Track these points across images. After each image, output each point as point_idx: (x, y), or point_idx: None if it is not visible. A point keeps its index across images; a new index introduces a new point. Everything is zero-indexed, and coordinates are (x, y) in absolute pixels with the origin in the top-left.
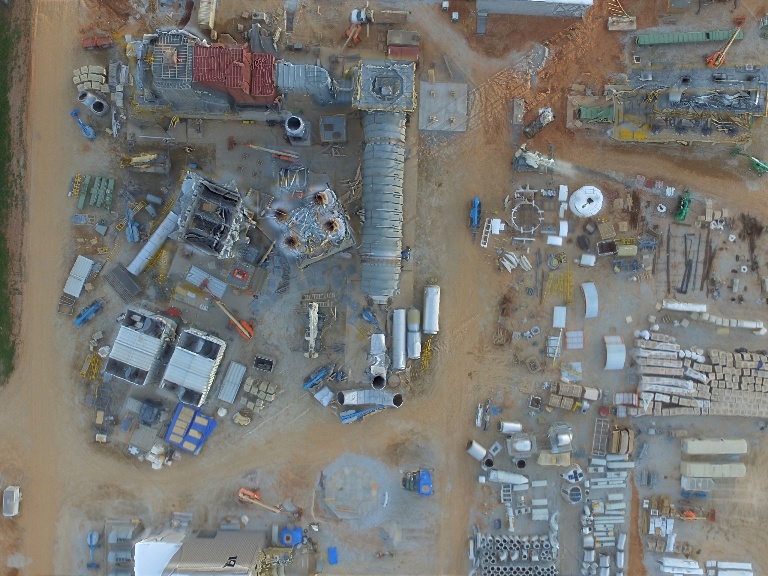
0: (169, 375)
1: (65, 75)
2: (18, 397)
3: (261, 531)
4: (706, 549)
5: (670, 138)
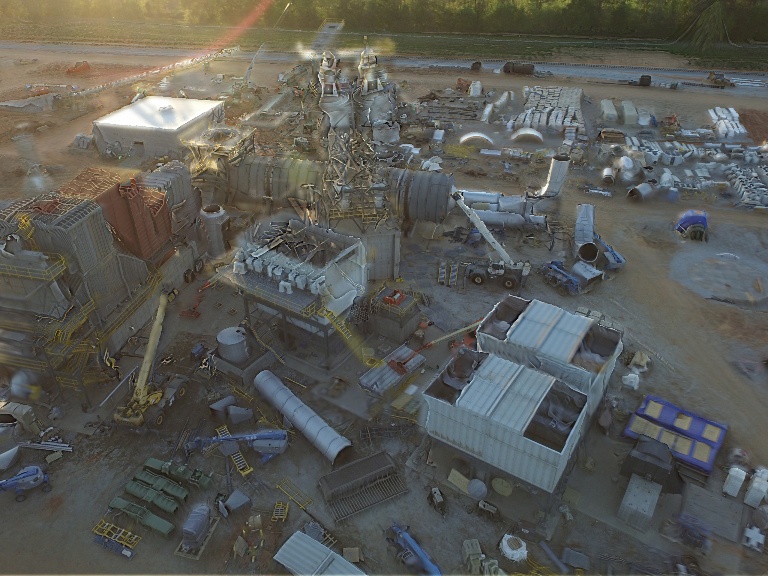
0: (563, 354)
1: None
2: None
3: None
4: (704, 123)
5: None
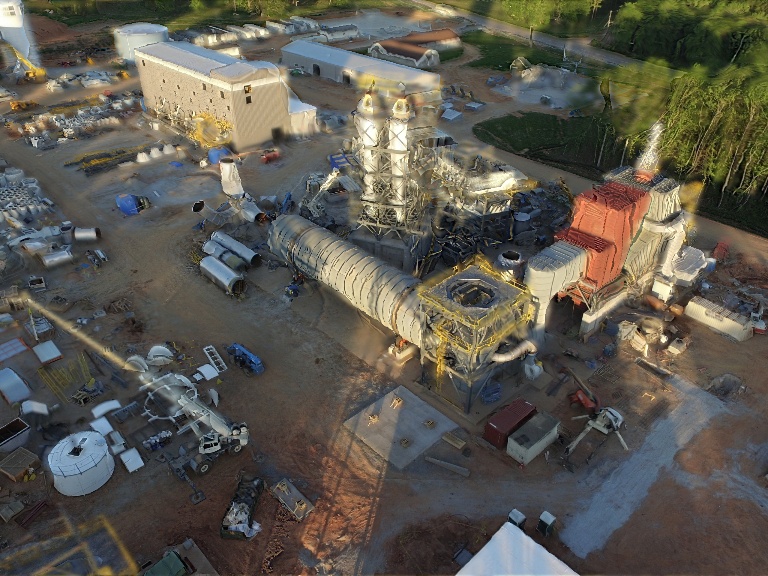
0: None
1: (698, 231)
2: (462, 136)
3: (244, 151)
4: None
5: None
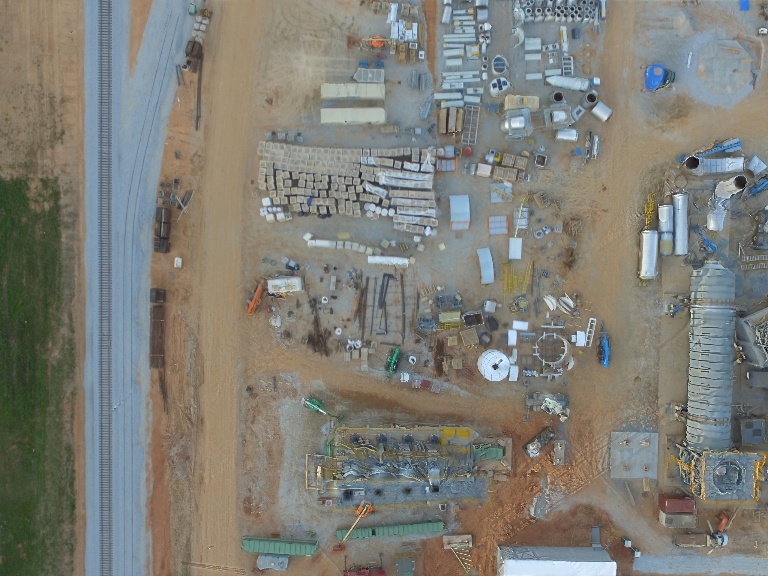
0: None
1: None
2: None
3: None
4: (355, 6)
5: (417, 431)
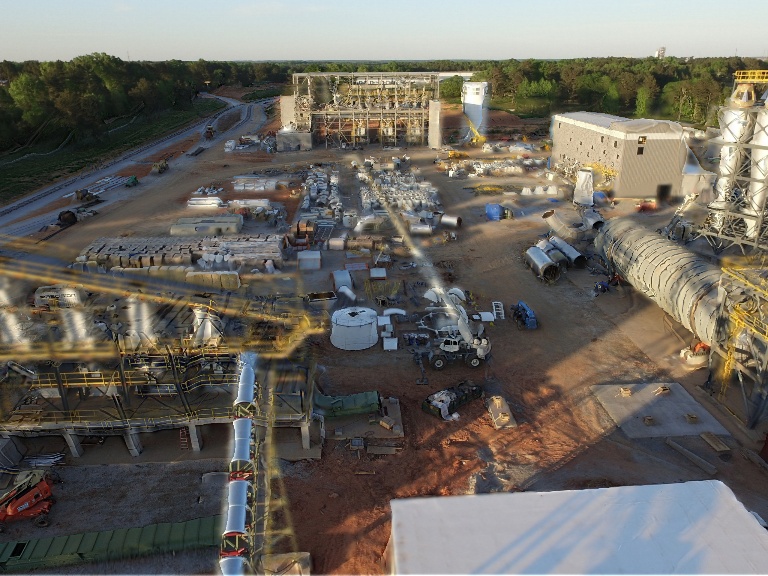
0: None
1: None
2: None
3: None
4: (226, 211)
5: None
